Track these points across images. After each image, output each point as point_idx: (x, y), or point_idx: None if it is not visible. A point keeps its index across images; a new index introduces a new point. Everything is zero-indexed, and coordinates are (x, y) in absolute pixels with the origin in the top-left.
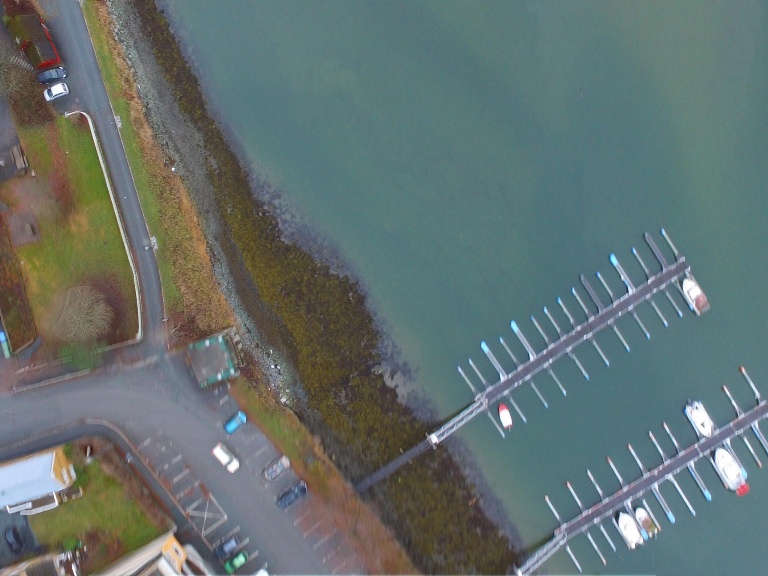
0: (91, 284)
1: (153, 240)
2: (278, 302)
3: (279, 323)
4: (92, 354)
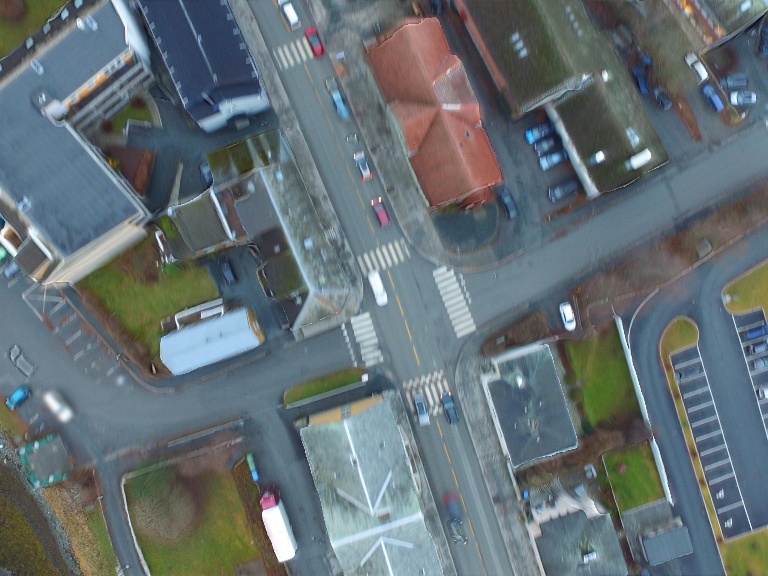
0: None
1: (122, 575)
2: (6, 510)
3: (3, 489)
4: (169, 461)
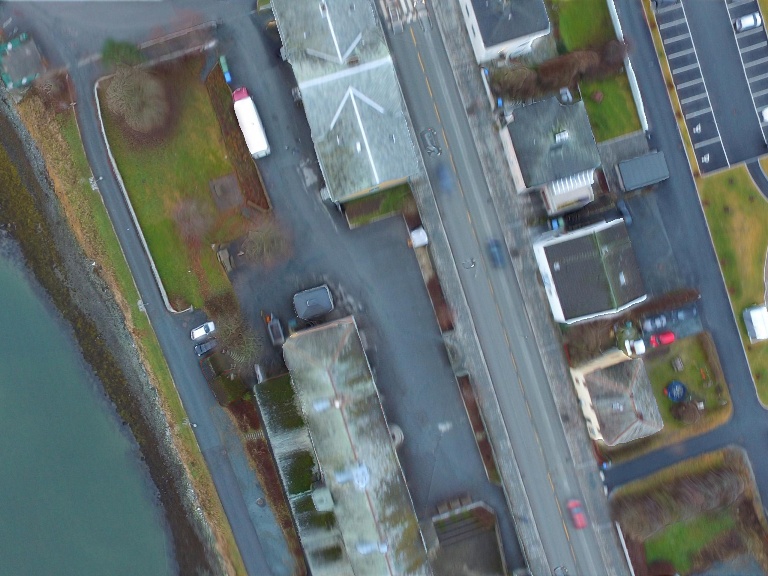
0: (152, 138)
1: (96, 187)
2: None
3: None
4: (142, 64)
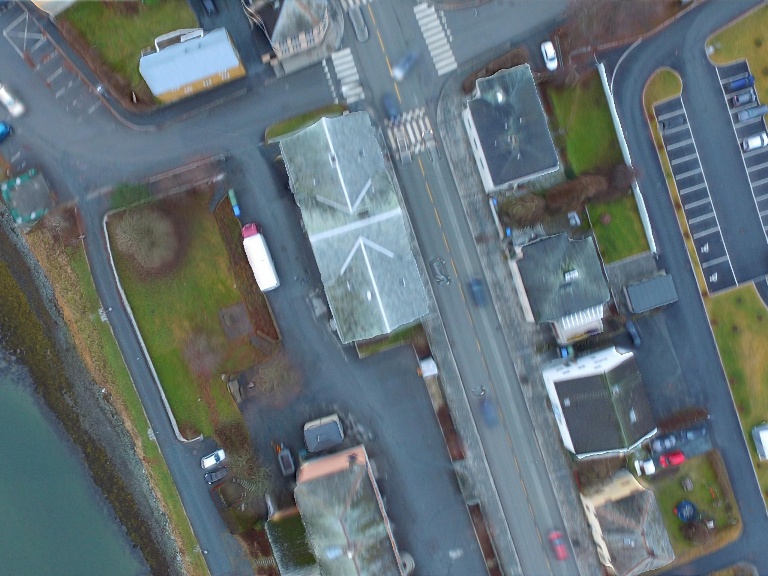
0: (161, 269)
1: (105, 318)
2: None
3: None
4: (151, 198)
